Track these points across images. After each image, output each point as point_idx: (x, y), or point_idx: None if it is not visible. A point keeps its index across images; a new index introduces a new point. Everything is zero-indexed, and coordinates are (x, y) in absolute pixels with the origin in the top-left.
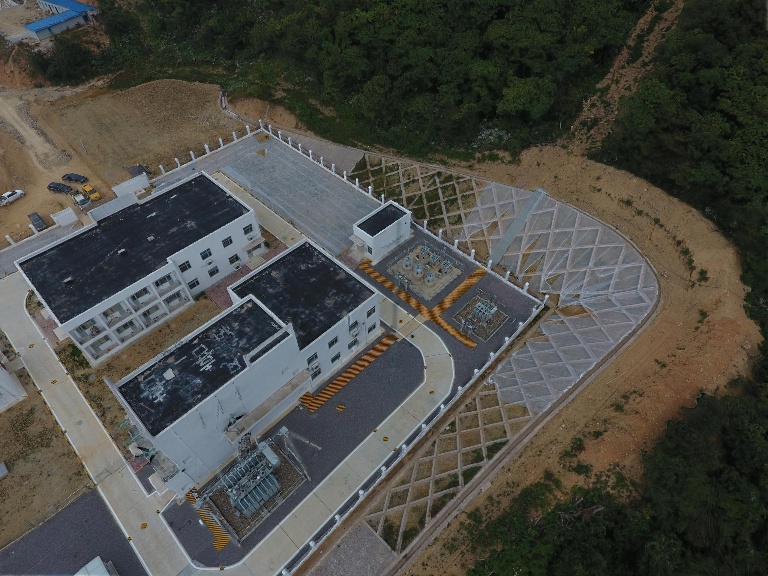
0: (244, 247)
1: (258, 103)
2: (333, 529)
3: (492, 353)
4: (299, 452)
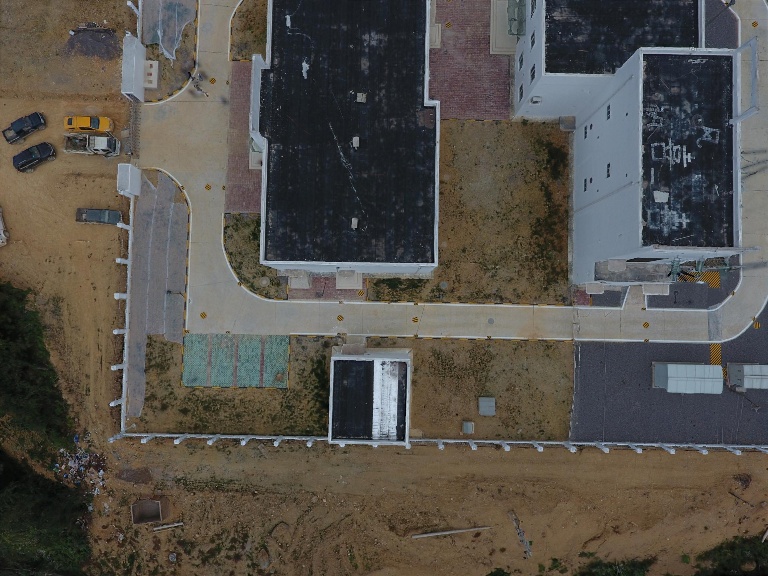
0: None
1: None
2: None
3: None
4: None
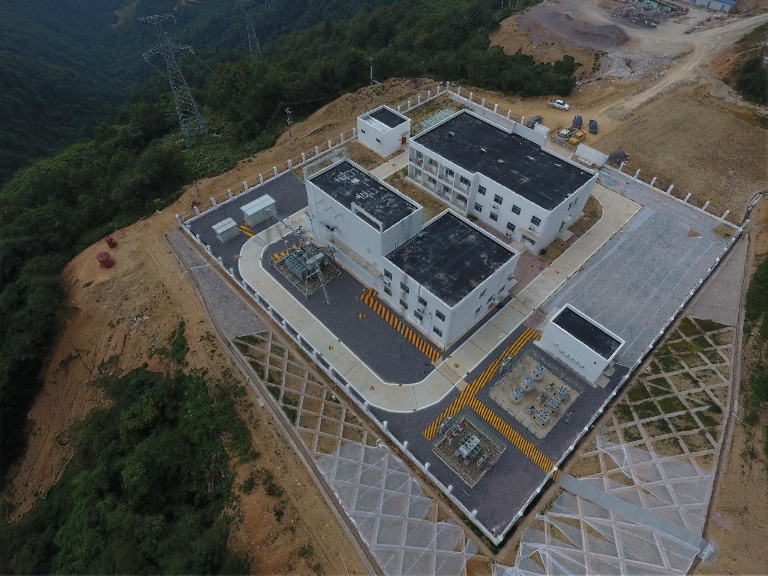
0: (523, 228)
1: None
2: (269, 314)
3: (406, 442)
4: (328, 291)
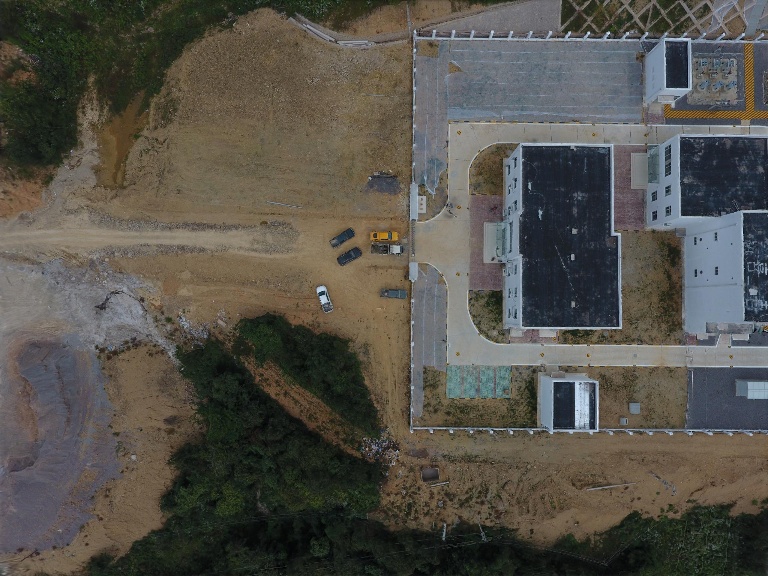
0: None
1: (390, 10)
2: None
3: None
4: None
